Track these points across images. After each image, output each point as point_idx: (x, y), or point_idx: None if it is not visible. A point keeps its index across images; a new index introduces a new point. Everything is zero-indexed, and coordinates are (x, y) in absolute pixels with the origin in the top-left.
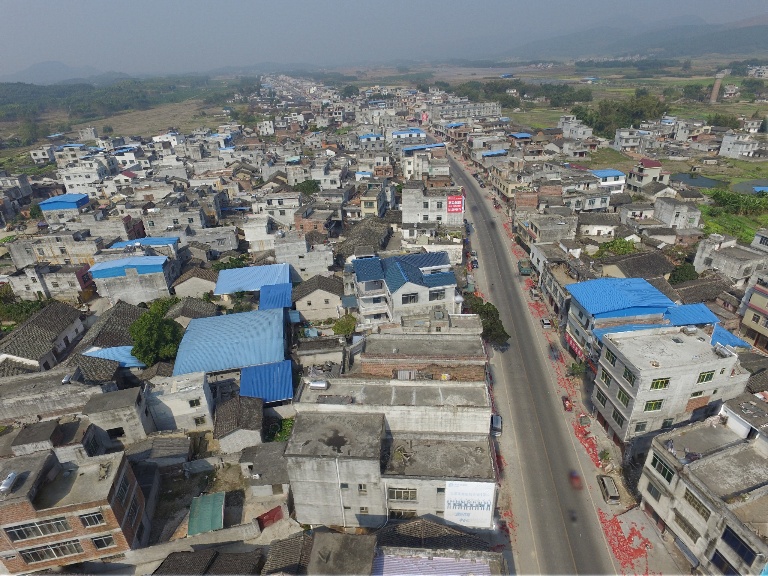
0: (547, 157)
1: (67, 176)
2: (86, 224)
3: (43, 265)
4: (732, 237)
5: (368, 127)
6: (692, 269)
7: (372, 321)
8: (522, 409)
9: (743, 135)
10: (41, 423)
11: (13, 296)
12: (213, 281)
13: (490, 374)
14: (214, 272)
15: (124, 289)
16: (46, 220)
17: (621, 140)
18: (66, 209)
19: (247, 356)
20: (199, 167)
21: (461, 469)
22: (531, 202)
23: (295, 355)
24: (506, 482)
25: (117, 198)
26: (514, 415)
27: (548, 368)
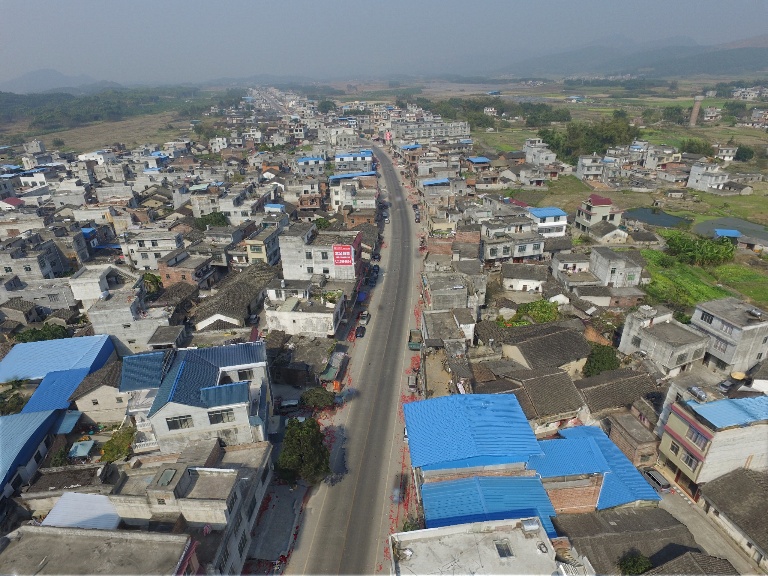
0: (501, 185)
1: None
2: None
3: None
4: (667, 310)
5: (320, 147)
6: (611, 355)
7: None
8: None
9: (712, 166)
10: None
11: None
12: None
13: (297, 528)
14: (9, 346)
15: None
16: None
17: (583, 168)
18: None
19: None
20: (102, 193)
21: None
22: (446, 250)
23: (19, 499)
24: None
25: None
26: None
27: (382, 519)
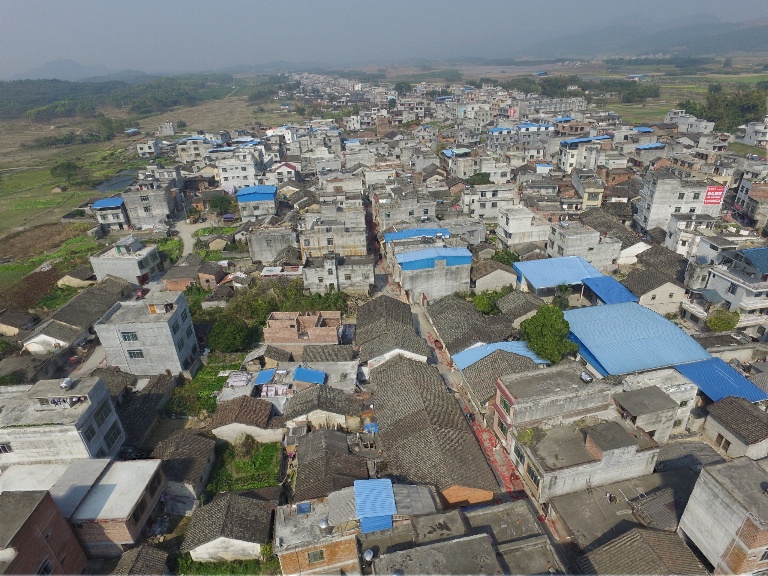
0: (685, 151)
1: (223, 168)
2: (326, 215)
3: (336, 256)
4: None
5: (472, 121)
6: None
7: (745, 316)
8: None
9: None
10: (601, 425)
11: (302, 289)
12: (516, 274)
13: None
14: (506, 265)
15: (427, 282)
16: (240, 212)
17: (756, 134)
18: (262, 201)
19: (669, 353)
20: (350, 160)
21: None
22: None
23: None
24: None
25: (285, 191)
26: None
27: None
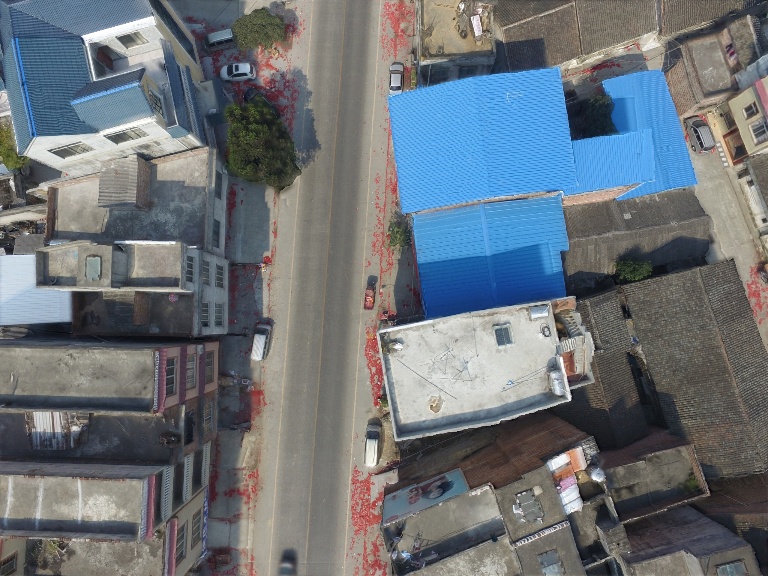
0: None
1: None
2: None
3: None
4: None
5: None
6: None
7: None
8: (306, 304)
9: None
10: None
11: None
12: None
13: (275, 225)
14: None
15: None
16: None
17: None
18: None
19: None
20: None
21: (129, 567)
22: None
23: None
24: (259, 432)
25: None
26: (292, 317)
27: (367, 209)
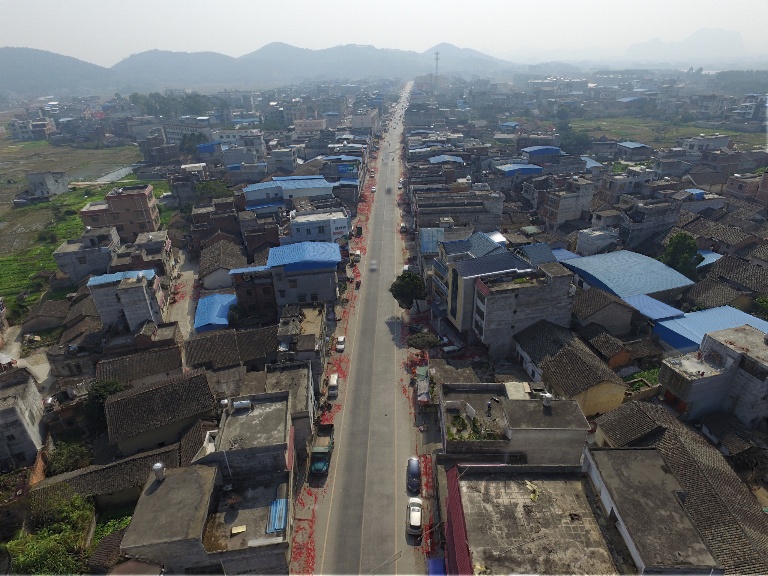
0: None
1: None
2: None
3: None
4: None
5: None
6: None
7: None
8: (388, 282)
9: None
10: None
11: None
12: None
13: None
14: None
15: None
16: None
17: None
18: None
19: None
20: None
21: None
22: None
23: None
24: None
25: None
26: (394, 280)
27: (359, 305)
